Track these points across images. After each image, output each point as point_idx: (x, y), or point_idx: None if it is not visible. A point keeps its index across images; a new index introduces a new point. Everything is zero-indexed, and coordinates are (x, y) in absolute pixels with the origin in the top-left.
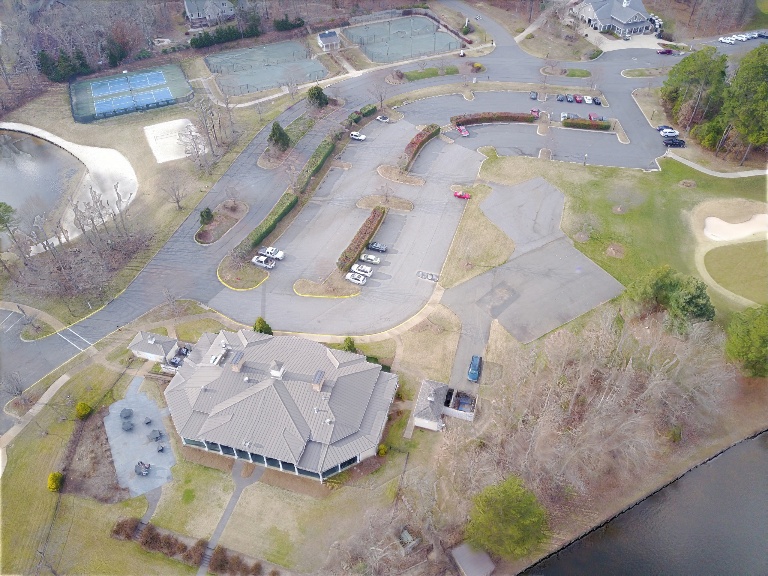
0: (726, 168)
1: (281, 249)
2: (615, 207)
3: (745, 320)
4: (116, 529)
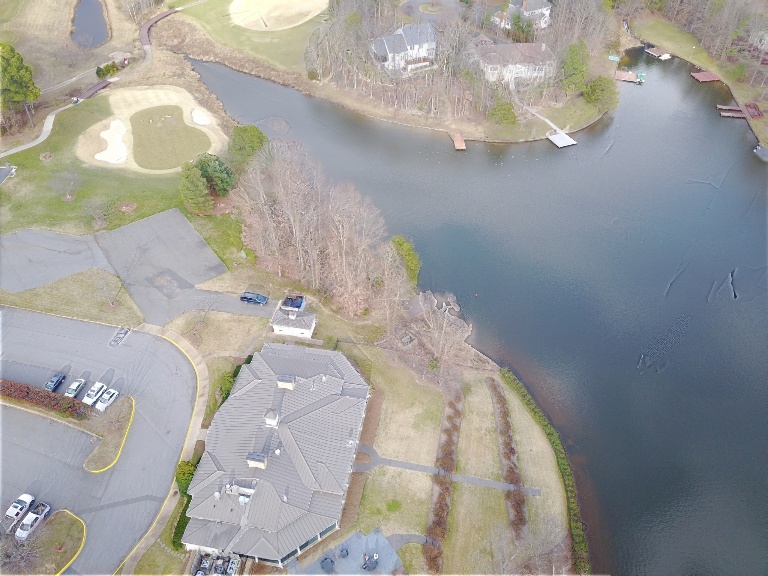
0: (33, 134)
1: (7, 505)
2: (64, 199)
3: (239, 148)
4: (435, 569)
